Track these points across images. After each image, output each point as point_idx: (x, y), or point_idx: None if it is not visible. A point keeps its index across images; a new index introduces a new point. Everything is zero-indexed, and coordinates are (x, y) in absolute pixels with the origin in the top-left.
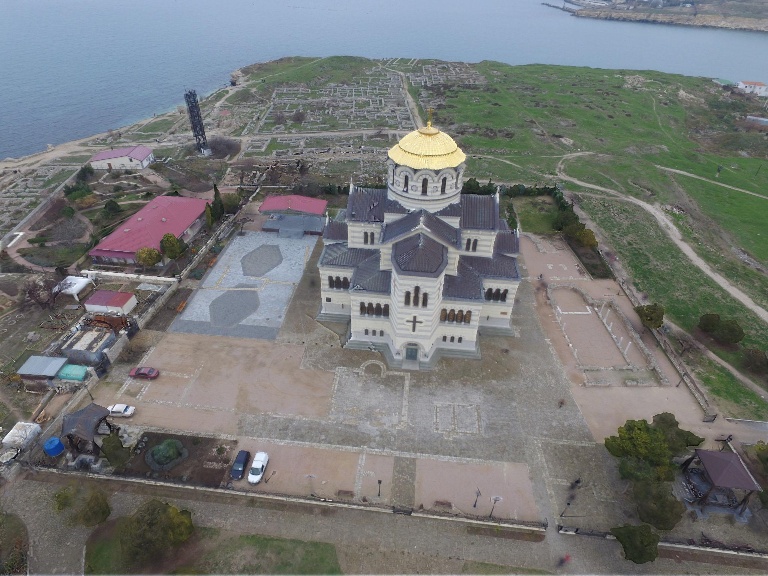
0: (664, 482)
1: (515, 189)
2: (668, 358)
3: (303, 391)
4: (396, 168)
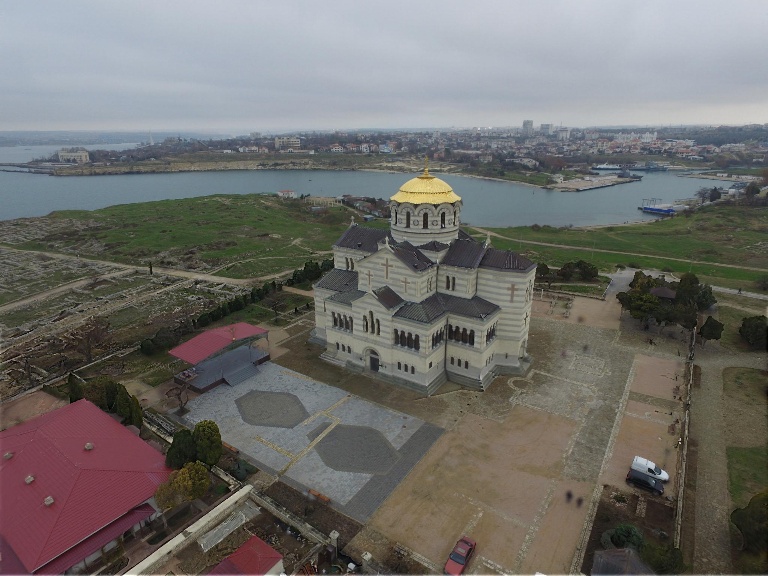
0: (651, 322)
1: None
2: (550, 291)
3: (538, 427)
4: (437, 208)
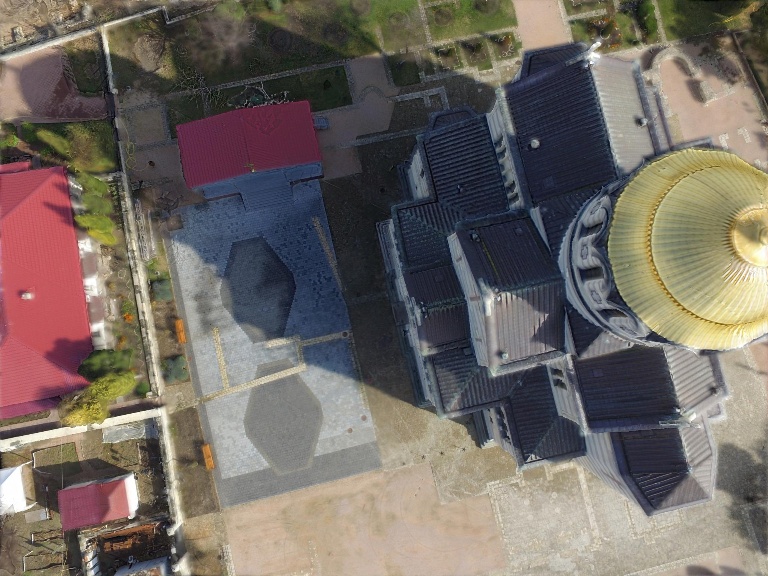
0: None
1: None
2: None
3: (464, 540)
4: None
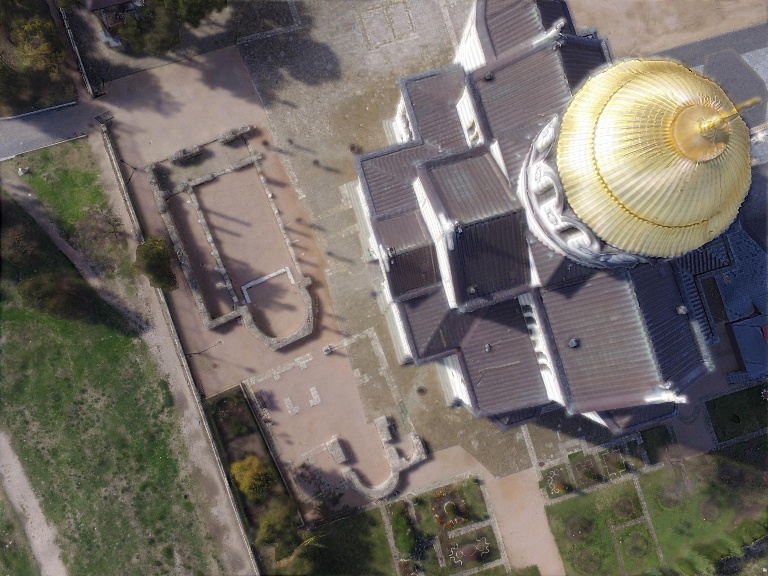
0: None
1: None
2: (139, 220)
3: None
4: None
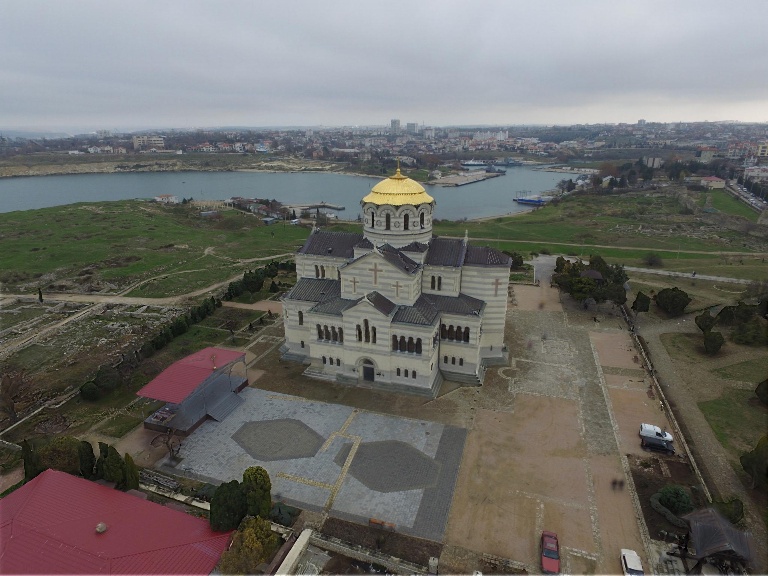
0: (586, 302)
1: (275, 268)
2: None
3: (546, 412)
4: (418, 208)
